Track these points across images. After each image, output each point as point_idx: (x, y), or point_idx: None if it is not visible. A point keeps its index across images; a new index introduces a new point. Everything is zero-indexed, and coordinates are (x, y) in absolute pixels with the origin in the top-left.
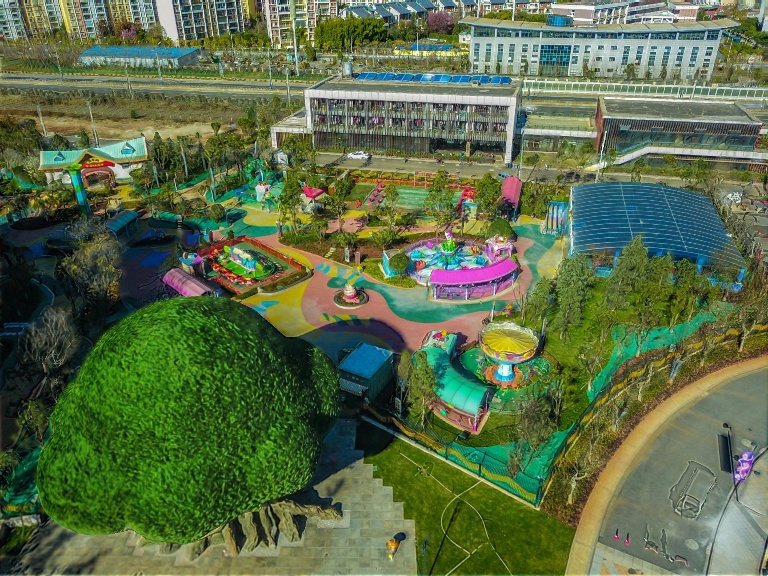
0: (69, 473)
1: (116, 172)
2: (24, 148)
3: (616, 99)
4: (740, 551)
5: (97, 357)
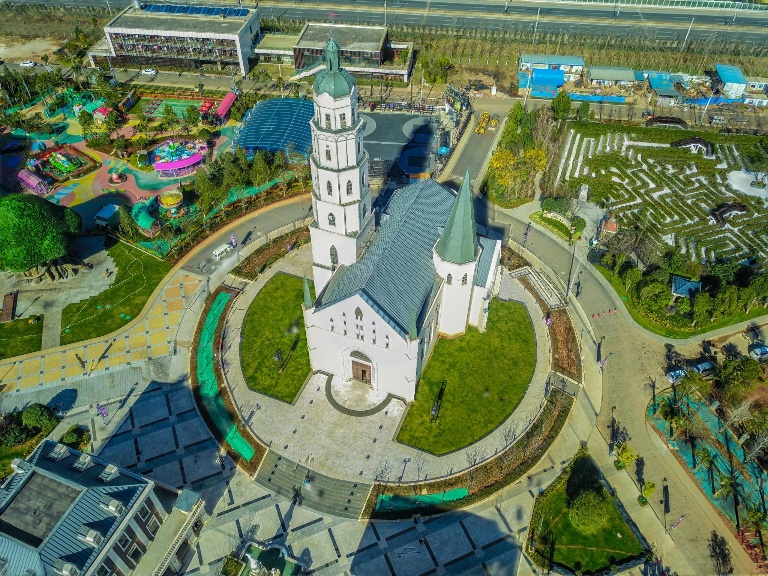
0: None
1: None
2: None
3: (316, 25)
4: (227, 268)
5: None
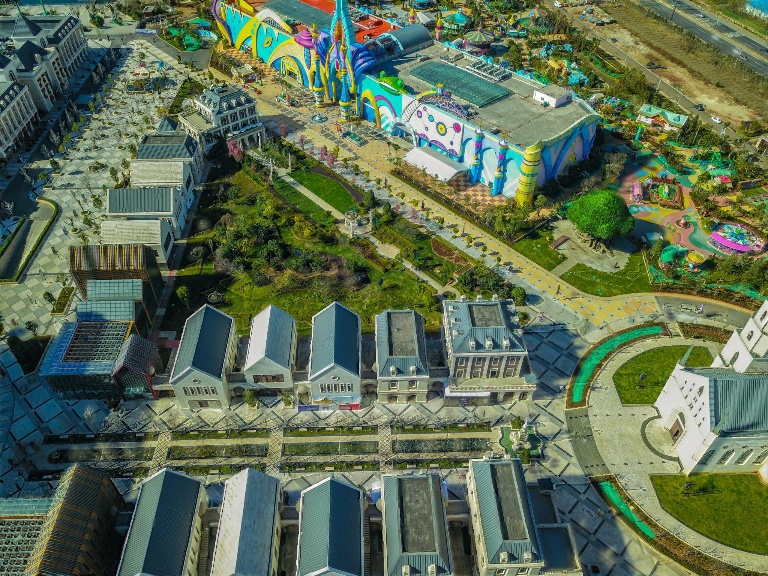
0: (573, 209)
1: (666, 126)
2: (641, 97)
3: None
4: None
5: (591, 193)
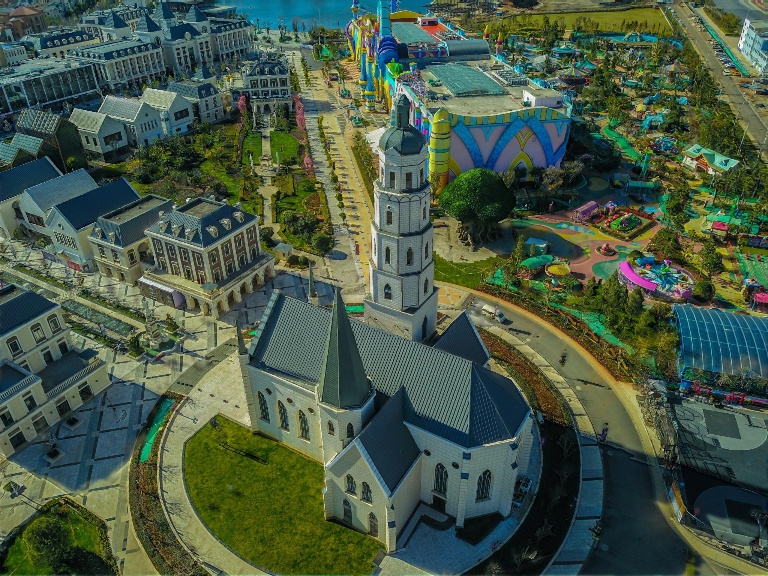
0: None
1: (709, 172)
2: None
3: None
4: None
5: None
